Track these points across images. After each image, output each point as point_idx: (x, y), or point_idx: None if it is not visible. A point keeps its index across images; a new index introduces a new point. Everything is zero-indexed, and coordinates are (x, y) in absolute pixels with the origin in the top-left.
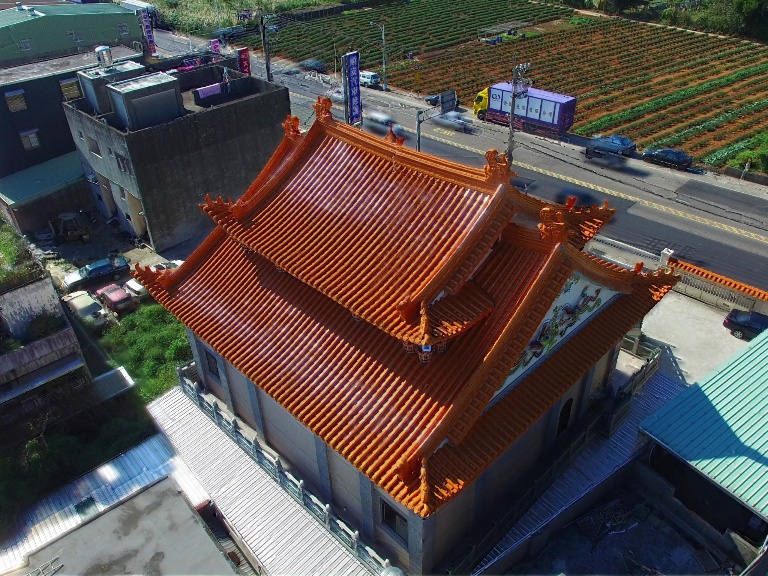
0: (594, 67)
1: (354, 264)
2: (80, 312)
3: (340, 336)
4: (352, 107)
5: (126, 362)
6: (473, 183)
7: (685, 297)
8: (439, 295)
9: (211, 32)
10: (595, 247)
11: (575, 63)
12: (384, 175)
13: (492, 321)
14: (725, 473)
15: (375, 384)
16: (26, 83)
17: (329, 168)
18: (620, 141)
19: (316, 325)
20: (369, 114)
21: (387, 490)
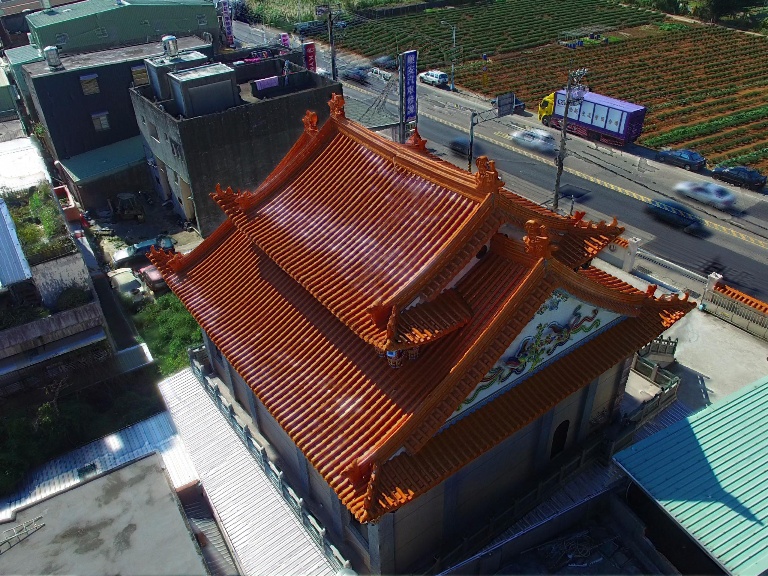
0: (676, 76)
1: (340, 263)
2: (121, 288)
3: (323, 333)
4: (407, 106)
5: (155, 339)
6: (465, 190)
7: (730, 326)
8: (415, 301)
9: (284, 26)
10: (642, 265)
11: (656, 71)
12: (384, 176)
13: (467, 332)
14: (695, 518)
15: (346, 384)
16: (100, 68)
17: (336, 165)
18: (689, 155)
19: (303, 320)
20: (431, 114)
21: (336, 491)
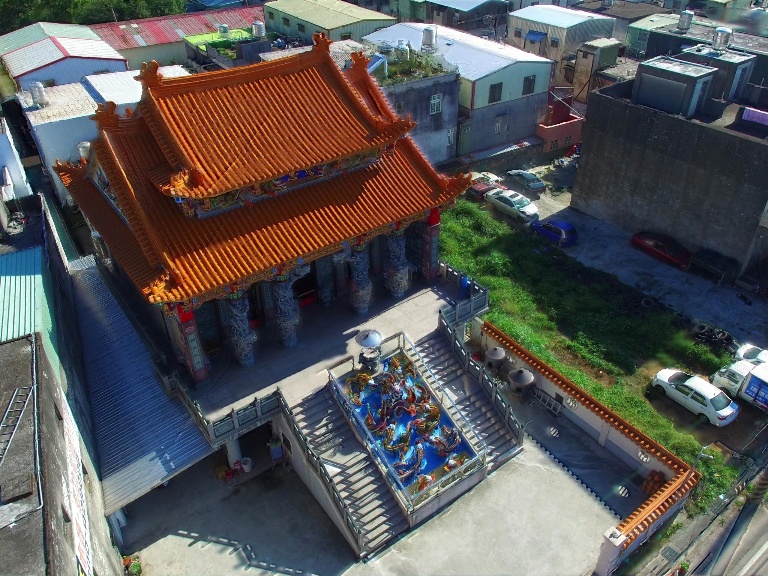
0: None
1: None
2: None
3: None
4: None
5: None
6: None
7: None
8: None
9: None
10: None
11: None
12: None
13: None
14: None
15: None
16: None
17: None
18: None
19: None
20: None
21: None
